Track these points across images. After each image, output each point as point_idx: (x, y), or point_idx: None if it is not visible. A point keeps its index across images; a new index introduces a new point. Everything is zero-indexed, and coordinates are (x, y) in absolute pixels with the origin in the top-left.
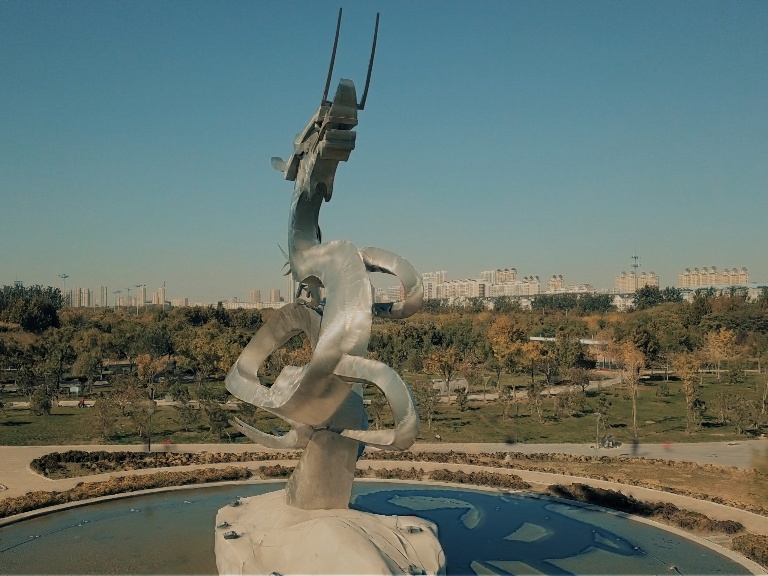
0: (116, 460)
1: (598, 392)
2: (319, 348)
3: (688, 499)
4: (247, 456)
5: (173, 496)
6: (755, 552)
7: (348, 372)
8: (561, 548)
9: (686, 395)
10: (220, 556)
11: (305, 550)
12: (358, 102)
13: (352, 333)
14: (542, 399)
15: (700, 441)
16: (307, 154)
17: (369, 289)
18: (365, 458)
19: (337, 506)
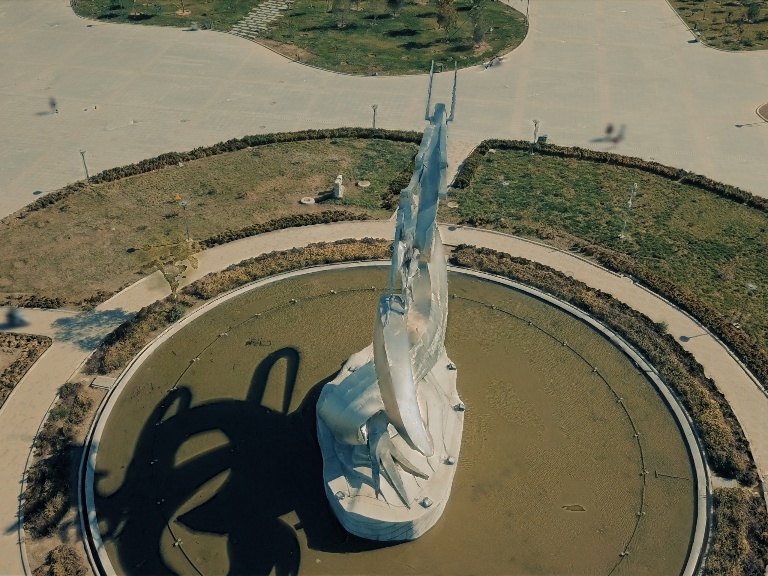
0: None
1: None
2: None
3: None
4: None
5: None
6: None
7: None
8: (217, 408)
9: None
10: None
11: None
12: (430, 116)
13: None
14: None
15: None
16: None
17: None
18: None
19: None
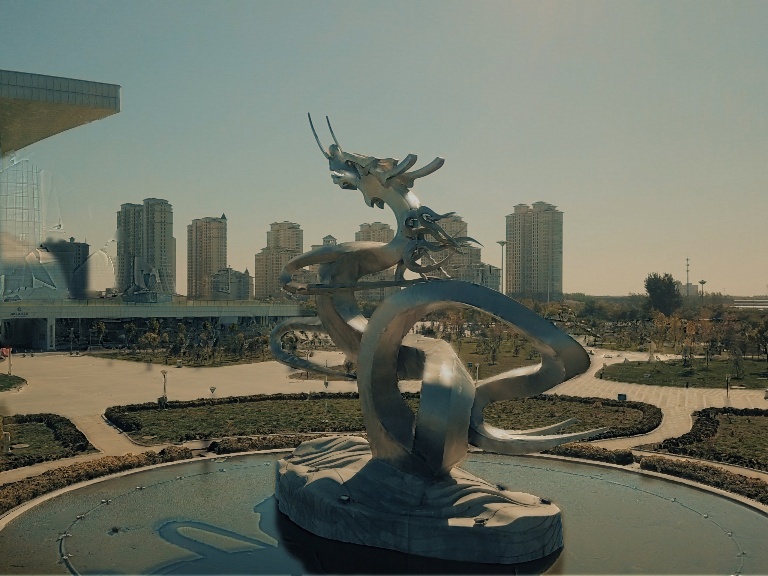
0: None
1: None
2: None
3: None
4: None
5: None
6: None
7: None
8: (184, 570)
9: None
10: None
11: None
12: None
13: None
14: None
15: None
16: None
17: None
18: None
19: None
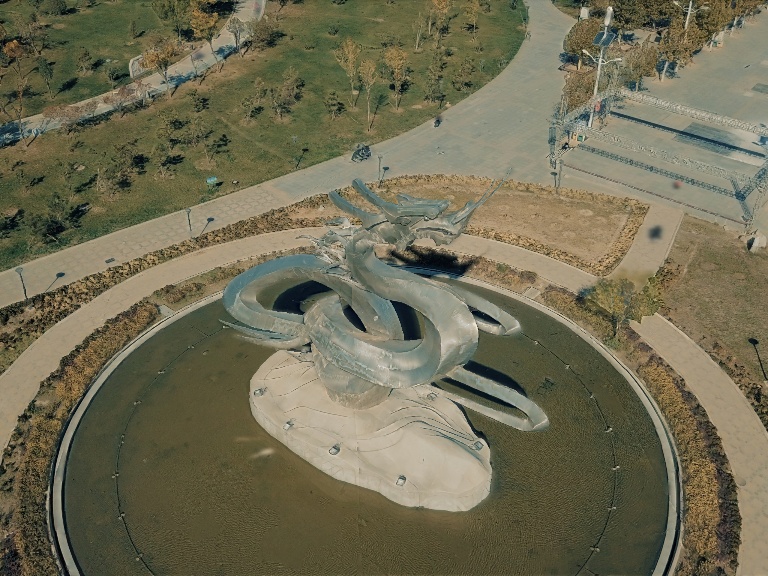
0: (3, 323)
1: (270, 32)
2: (440, 367)
3: (480, 240)
4: (118, 275)
5: (133, 365)
6: (565, 309)
7: (472, 384)
8: None
9: (396, 81)
10: (319, 459)
11: (408, 455)
12: None
13: (464, 355)
14: (279, 99)
15: (415, 125)
16: (405, 226)
17: (477, 329)
18: (216, 243)
19: (383, 400)
